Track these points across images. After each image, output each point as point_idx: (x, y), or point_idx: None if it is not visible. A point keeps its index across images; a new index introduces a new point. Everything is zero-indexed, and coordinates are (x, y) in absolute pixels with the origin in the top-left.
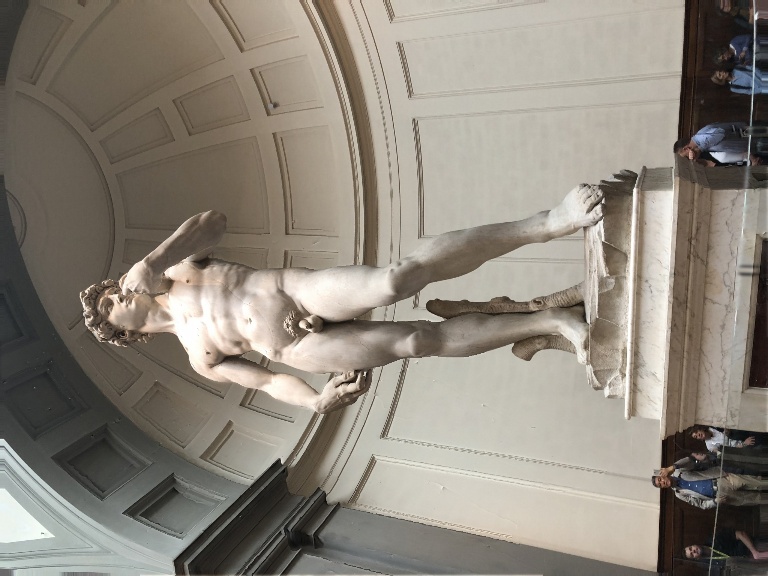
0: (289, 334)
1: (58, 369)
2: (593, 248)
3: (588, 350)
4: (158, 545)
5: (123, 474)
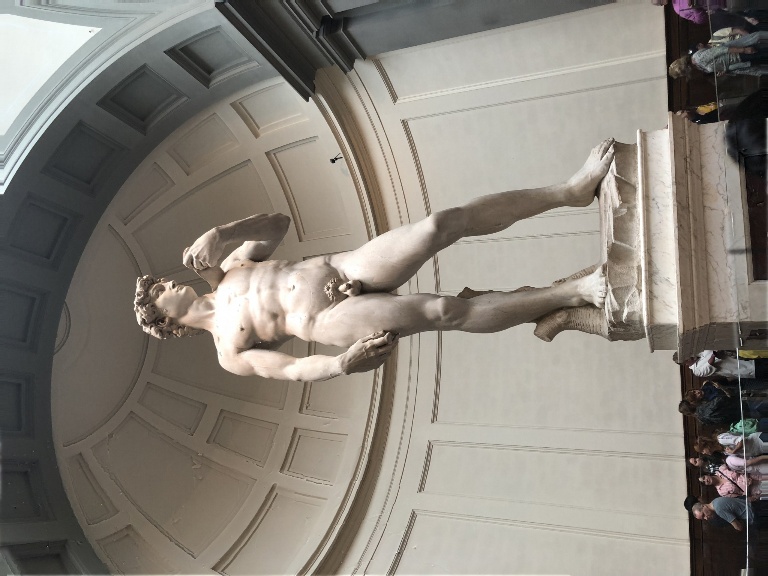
0: (328, 297)
1: (40, 473)
2: (607, 189)
3: (606, 276)
4: None
5: None
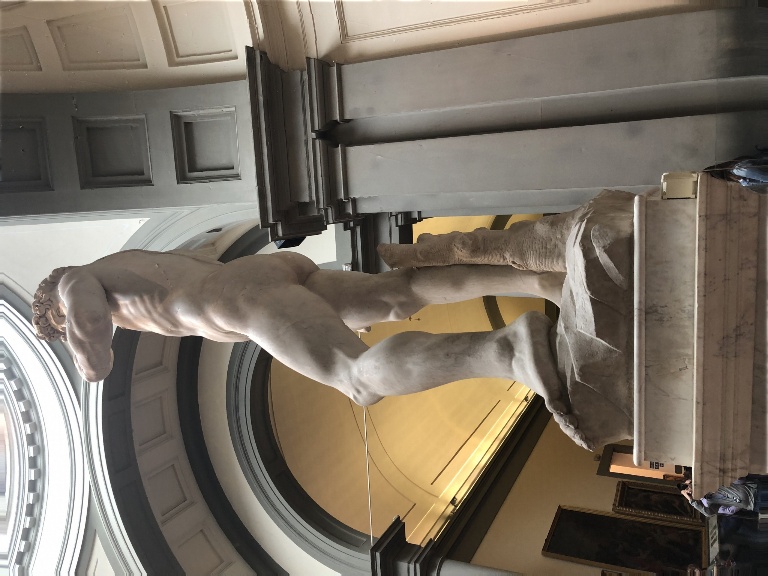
0: None
1: None
2: None
3: None
4: (230, 196)
5: (136, 141)
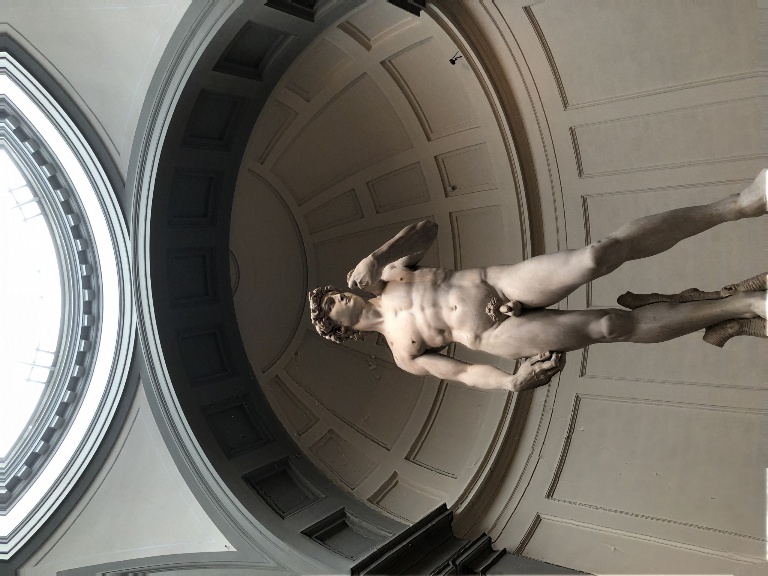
0: (490, 318)
1: (252, 403)
2: None
3: None
4: (332, 562)
5: (300, 502)
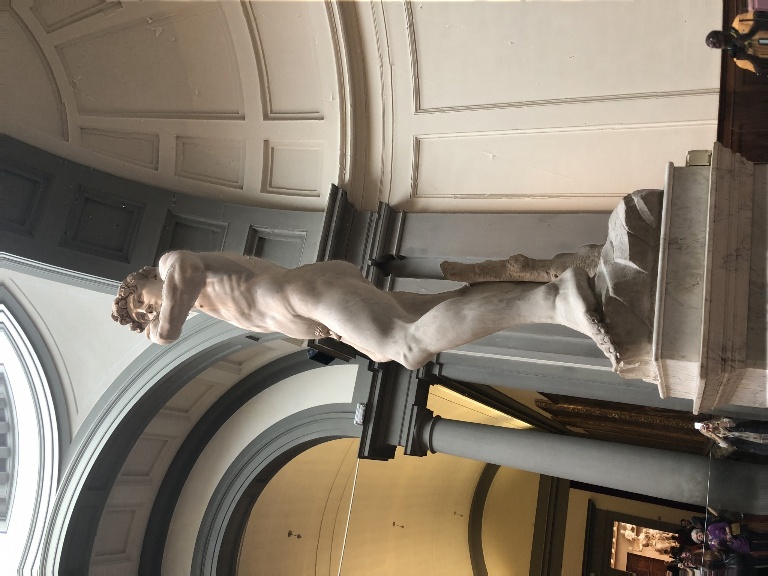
0: None
1: (93, 190)
2: None
3: None
4: None
5: (212, 243)
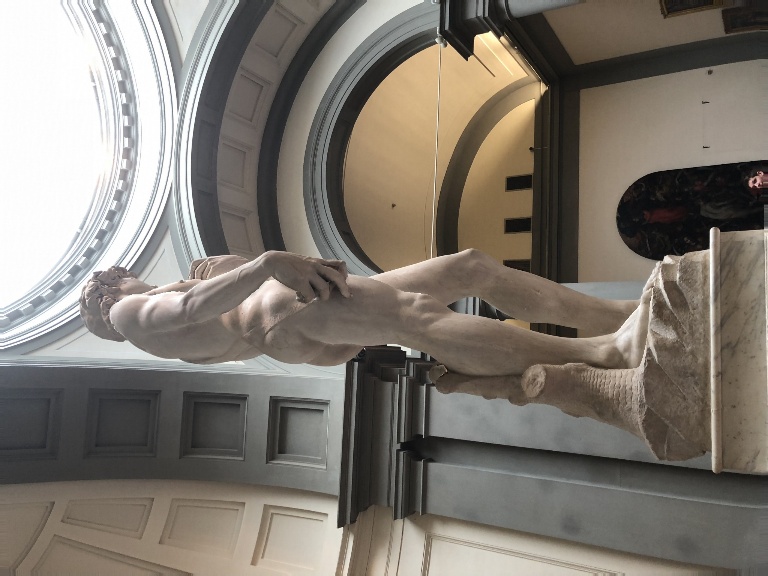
0: None
1: None
2: None
3: None
4: None
5: None
